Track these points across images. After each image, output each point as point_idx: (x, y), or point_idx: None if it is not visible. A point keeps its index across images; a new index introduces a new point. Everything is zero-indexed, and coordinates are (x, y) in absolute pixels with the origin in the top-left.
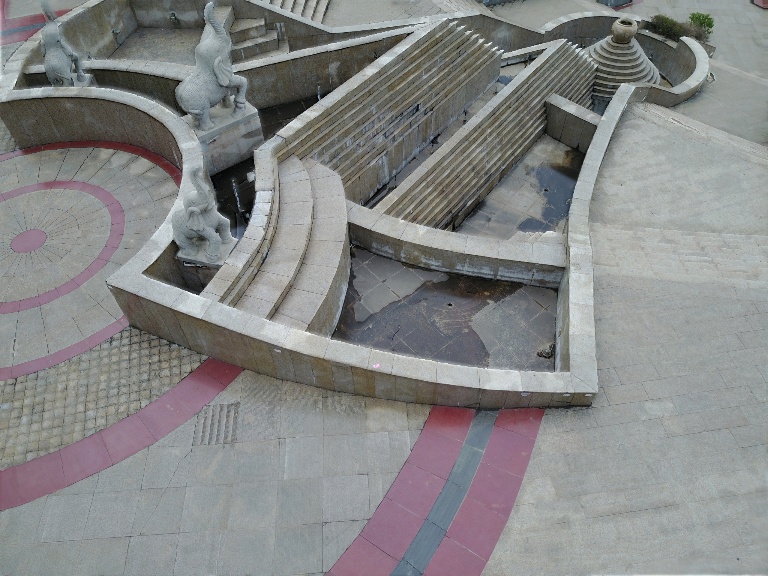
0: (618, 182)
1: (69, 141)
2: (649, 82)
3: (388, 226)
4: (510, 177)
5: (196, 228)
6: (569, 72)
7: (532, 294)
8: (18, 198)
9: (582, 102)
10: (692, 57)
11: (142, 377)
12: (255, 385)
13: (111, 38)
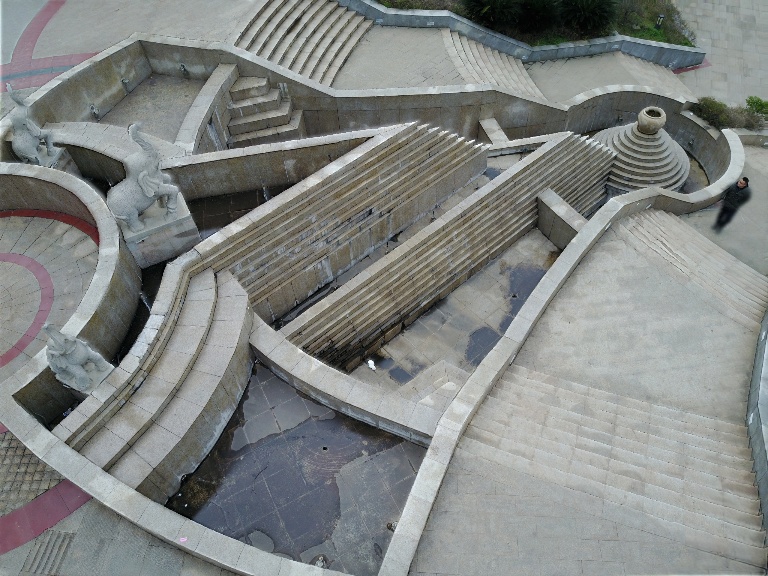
0: (567, 318)
1: (36, 209)
2: (673, 178)
3: (284, 355)
4: (482, 274)
5: (59, 366)
6: (575, 164)
7: (409, 452)
8: None
9: (591, 192)
10: (729, 155)
11: (5, 486)
12: (96, 517)
13: (120, 87)
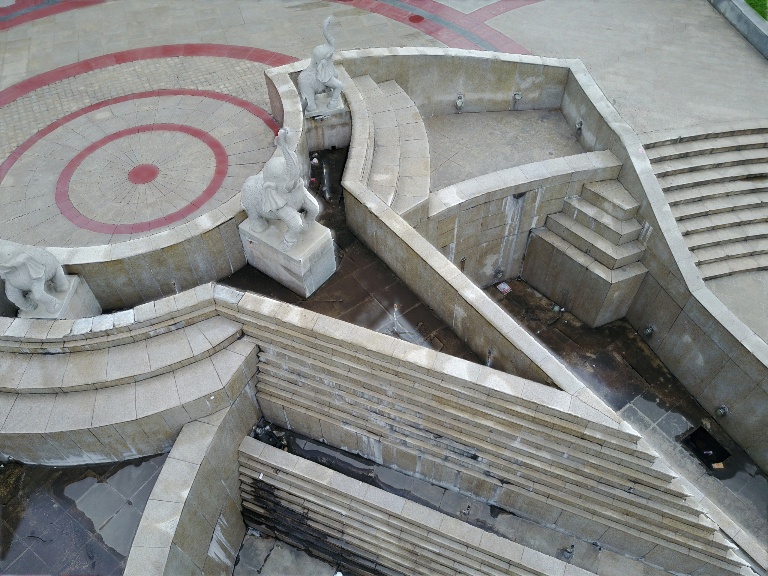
0: None
1: None
2: None
3: (174, 477)
4: None
5: None
6: None
7: None
8: (202, 144)
9: None
10: None
11: None
12: None
13: (509, 98)
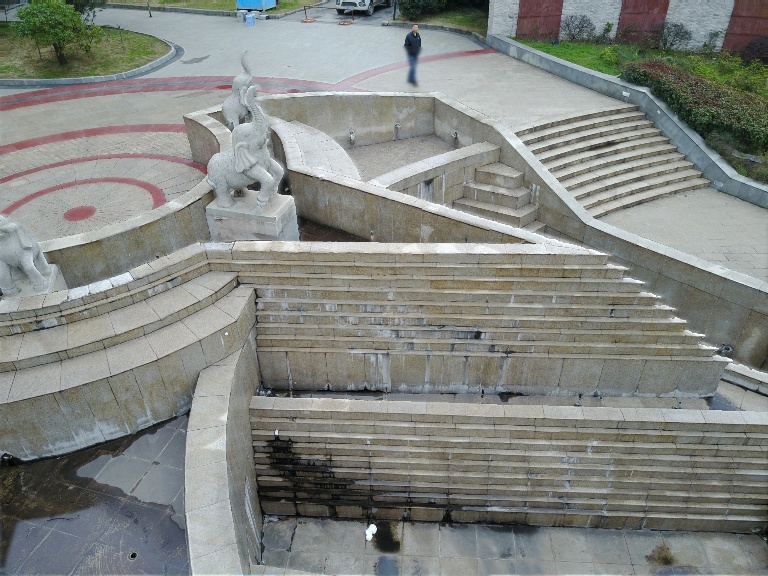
0: None
1: None
2: None
3: (207, 410)
4: (617, 537)
5: None
6: None
7: None
8: (132, 186)
9: None
10: None
11: None
12: None
13: (392, 129)
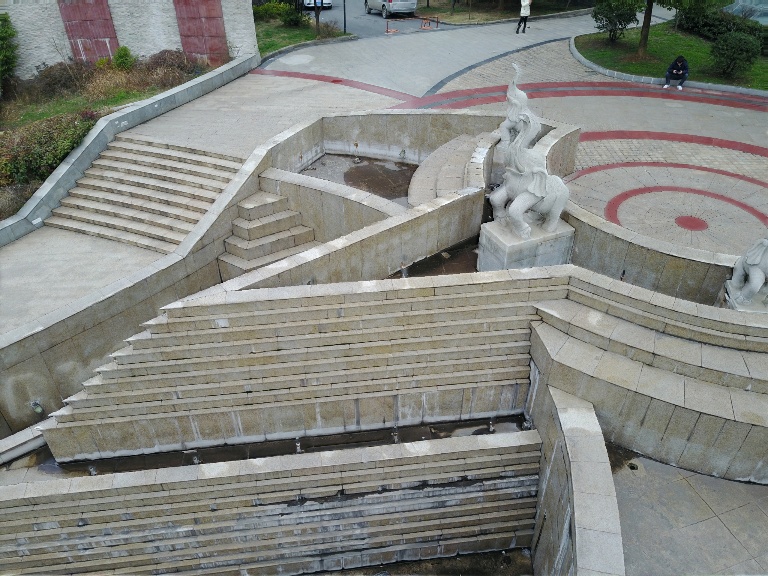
0: None
1: None
2: None
3: (378, 201)
4: None
5: None
6: None
7: None
8: None
9: None
10: None
11: None
12: None
13: None
